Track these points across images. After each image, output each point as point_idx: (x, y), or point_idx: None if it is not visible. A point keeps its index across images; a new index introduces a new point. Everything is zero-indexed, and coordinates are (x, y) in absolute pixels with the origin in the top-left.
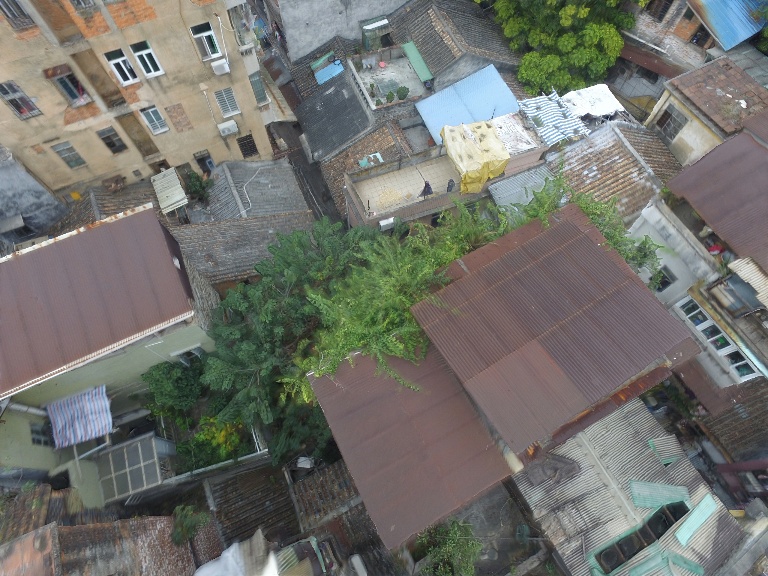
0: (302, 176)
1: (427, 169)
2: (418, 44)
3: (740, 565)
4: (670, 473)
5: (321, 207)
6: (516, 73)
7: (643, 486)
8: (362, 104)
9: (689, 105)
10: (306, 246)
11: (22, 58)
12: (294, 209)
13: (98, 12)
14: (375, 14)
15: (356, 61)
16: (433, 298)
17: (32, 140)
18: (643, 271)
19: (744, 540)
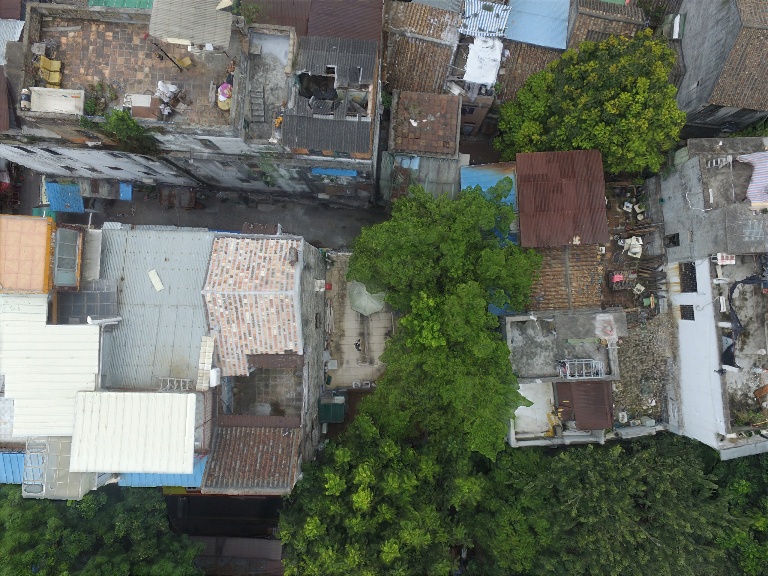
0: None
1: None
2: (617, 4)
3: None
4: None
5: None
6: None
7: None
8: None
9: None
10: None
11: None
12: None
13: None
14: None
15: None
16: None
17: None
18: None
19: None
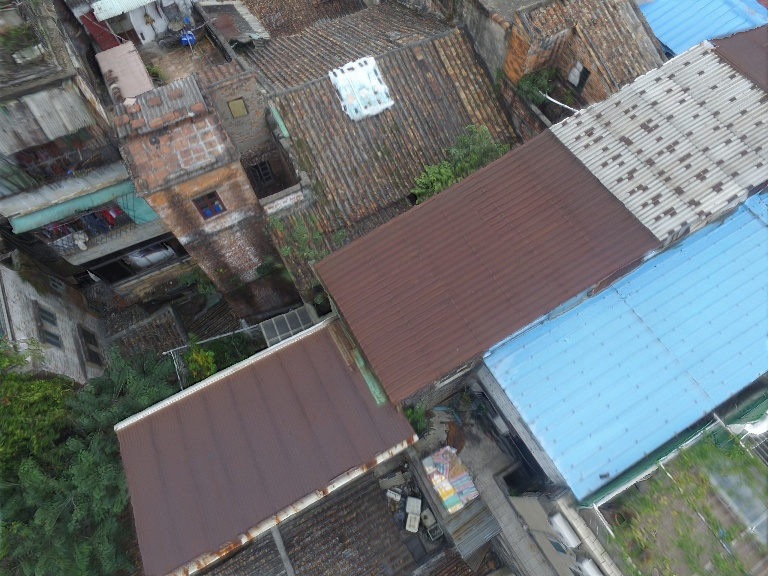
0: None
1: None
2: None
3: None
4: None
5: None
6: None
7: None
8: None
9: None
10: None
11: None
12: None
13: None
14: None
15: None
16: None
17: None
18: None
19: None
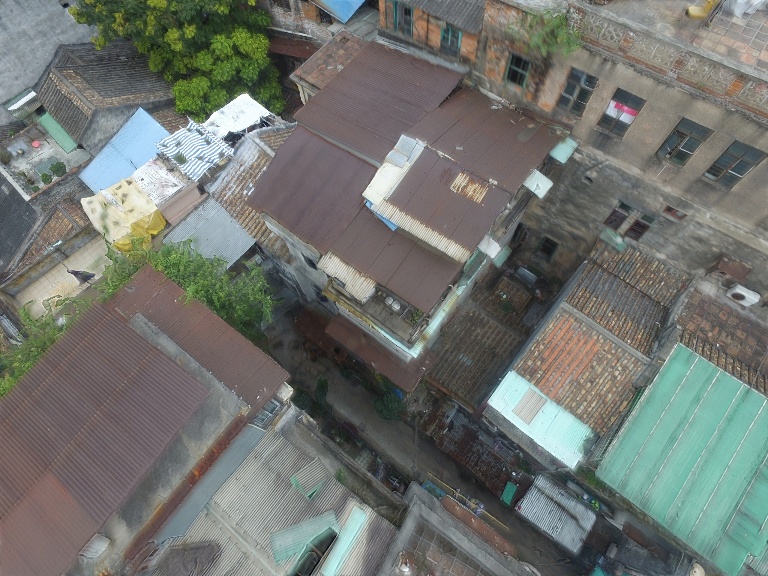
0: None
1: (99, 245)
2: (52, 114)
3: (381, 574)
4: (315, 502)
5: None
6: None
7: (285, 533)
8: None
9: (316, 91)
10: None
11: None
12: None
13: None
14: (16, 91)
15: None
16: None
17: None
18: (320, 272)
19: (393, 539)
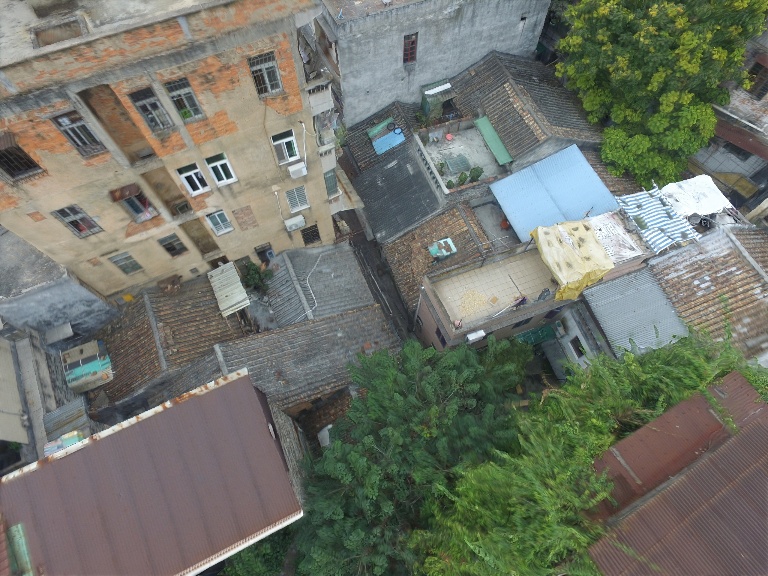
0: (362, 257)
1: (511, 267)
2: (493, 121)
3: None
4: None
5: (385, 294)
6: (597, 150)
7: None
8: (430, 183)
9: None
10: (402, 385)
11: (89, 182)
12: (360, 302)
13: (176, 132)
14: (438, 78)
15: (423, 135)
16: (615, 537)
17: (89, 255)
18: None
19: None
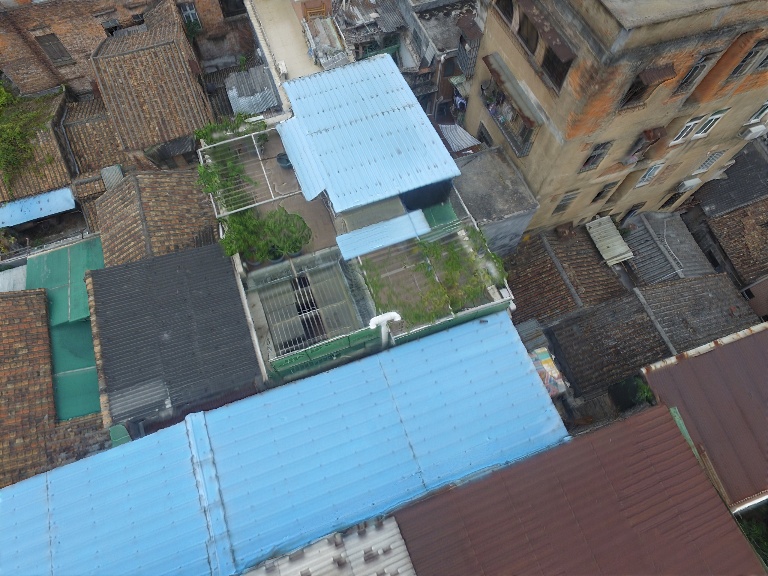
0: None
1: None
2: None
3: None
4: None
5: None
6: None
7: None
8: None
9: None
10: None
11: (644, 120)
12: (706, 268)
13: (737, 81)
14: None
15: None
16: None
17: (561, 190)
18: None
19: None
